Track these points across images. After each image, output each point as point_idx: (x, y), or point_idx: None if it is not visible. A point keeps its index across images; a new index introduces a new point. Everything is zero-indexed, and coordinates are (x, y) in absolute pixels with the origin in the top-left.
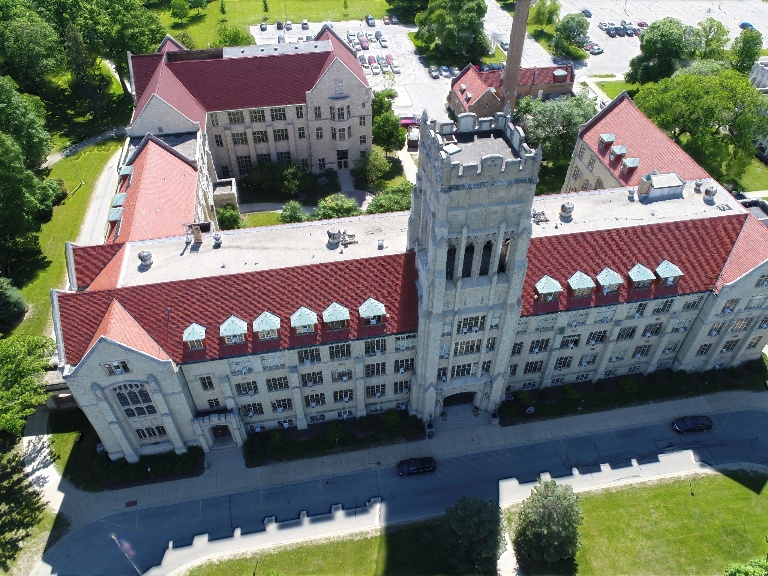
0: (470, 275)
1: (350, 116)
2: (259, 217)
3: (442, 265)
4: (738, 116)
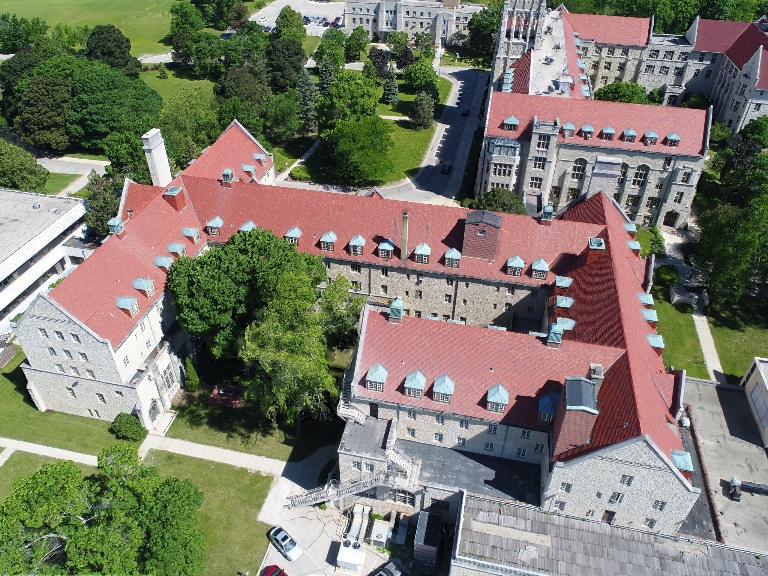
0: None
1: None
2: None
3: None
4: None
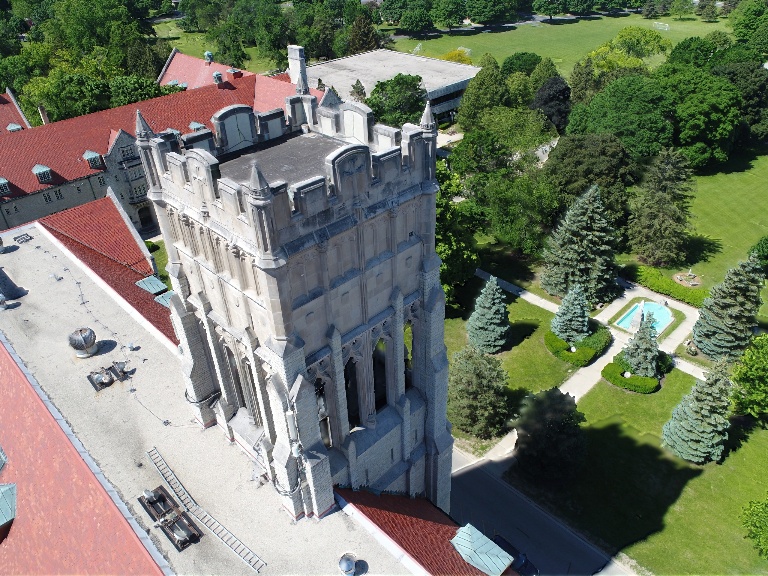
0: None
1: None
2: None
3: None
4: None
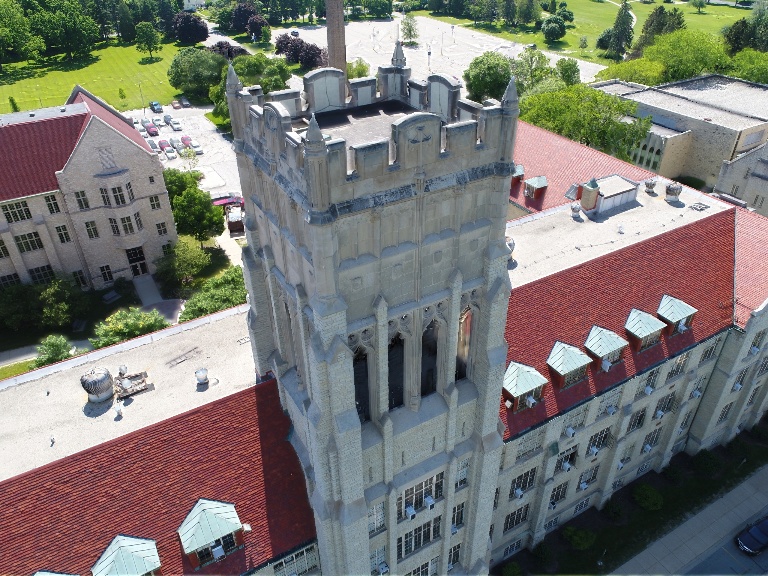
0: (402, 402)
1: (134, 198)
2: (7, 373)
3: (346, 399)
4: (605, 128)
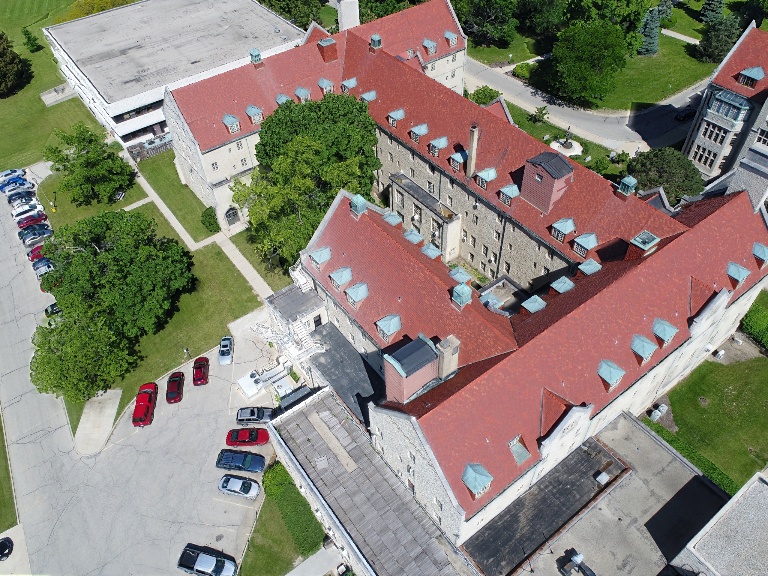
0: None
1: None
2: None
3: None
4: None
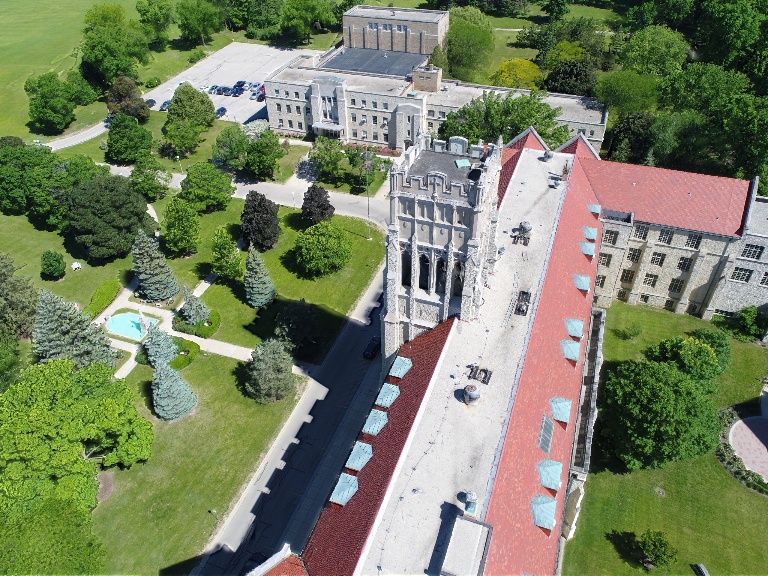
0: None
1: None
2: (759, 356)
3: None
4: None
